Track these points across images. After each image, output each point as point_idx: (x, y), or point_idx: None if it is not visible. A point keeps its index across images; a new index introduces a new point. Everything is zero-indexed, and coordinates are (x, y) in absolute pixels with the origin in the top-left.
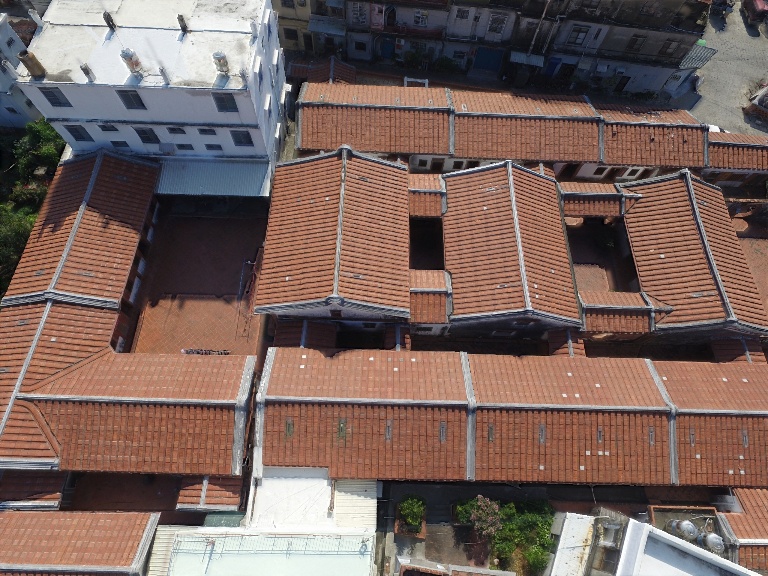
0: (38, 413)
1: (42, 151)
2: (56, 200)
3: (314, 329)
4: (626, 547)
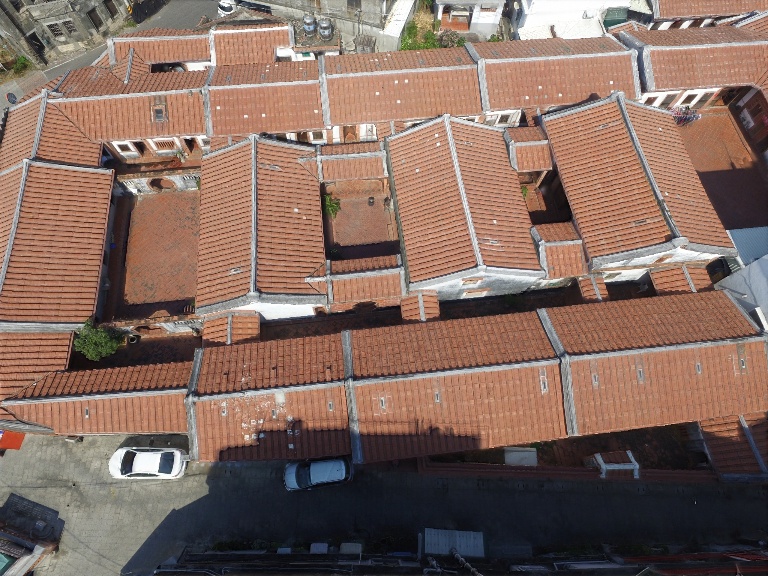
0: None
1: None
2: None
3: None
4: None
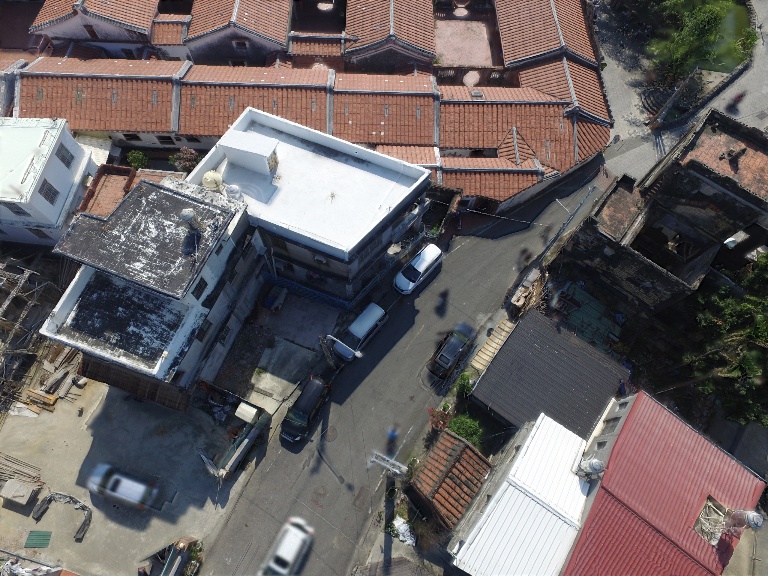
0: None
1: None
2: None
3: (79, 49)
4: None
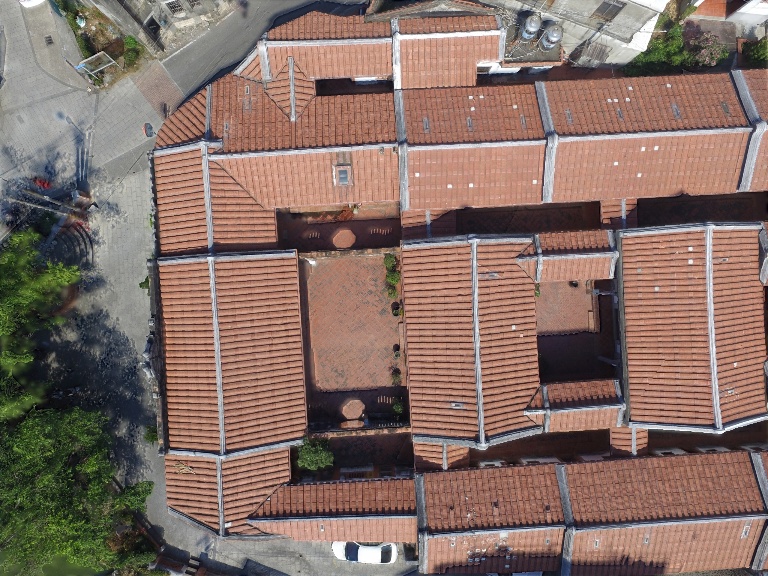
0: None
1: None
2: None
3: None
4: None
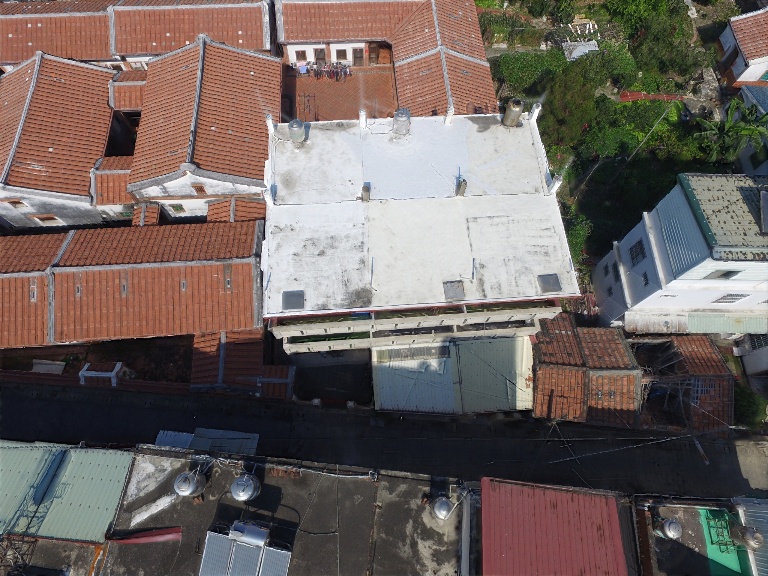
0: None
1: None
2: None
3: None
4: None
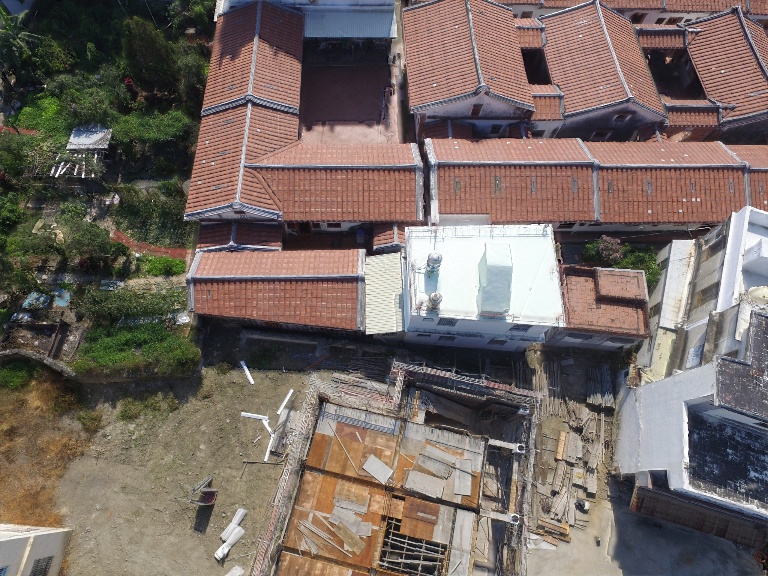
0: (261, 179)
1: (195, 10)
2: (226, 39)
3: (456, 127)
4: (732, 227)
